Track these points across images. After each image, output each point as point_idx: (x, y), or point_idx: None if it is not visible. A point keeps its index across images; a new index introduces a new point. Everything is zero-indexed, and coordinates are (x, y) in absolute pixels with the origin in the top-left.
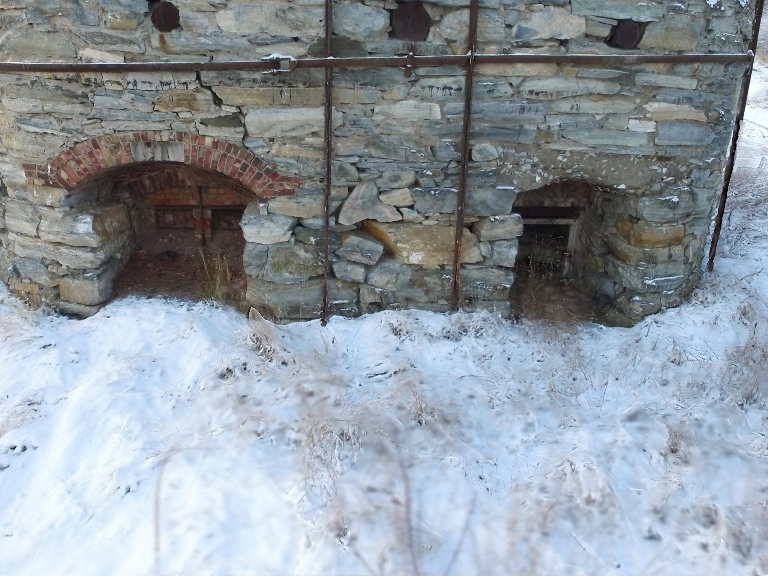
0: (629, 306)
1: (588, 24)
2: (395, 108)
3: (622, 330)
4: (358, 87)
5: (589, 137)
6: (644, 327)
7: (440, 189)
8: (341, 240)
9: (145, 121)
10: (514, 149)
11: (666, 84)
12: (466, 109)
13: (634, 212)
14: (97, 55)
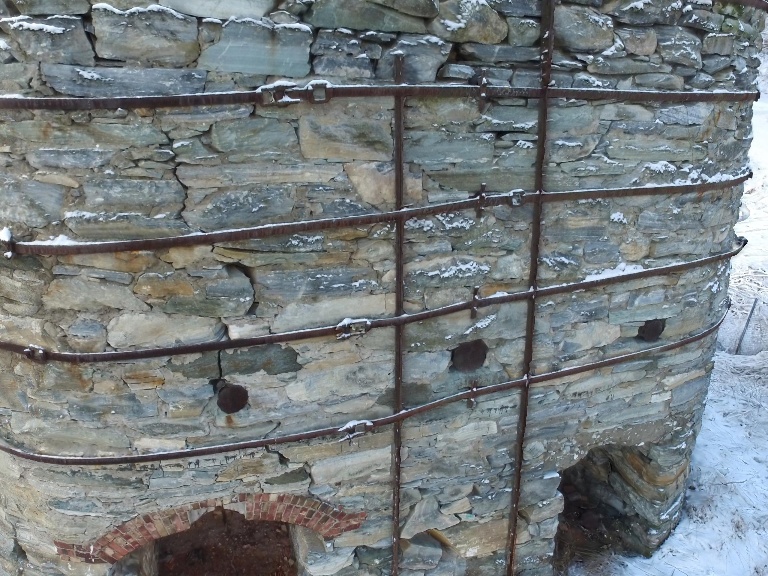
0: (647, 538)
1: (622, 330)
2: (457, 434)
3: (646, 566)
4: (424, 424)
5: (619, 416)
6: (662, 558)
7: (496, 492)
8: (401, 549)
9: (206, 493)
10: (557, 438)
11: (681, 362)
12: (521, 423)
13: (645, 452)
14: (155, 444)
